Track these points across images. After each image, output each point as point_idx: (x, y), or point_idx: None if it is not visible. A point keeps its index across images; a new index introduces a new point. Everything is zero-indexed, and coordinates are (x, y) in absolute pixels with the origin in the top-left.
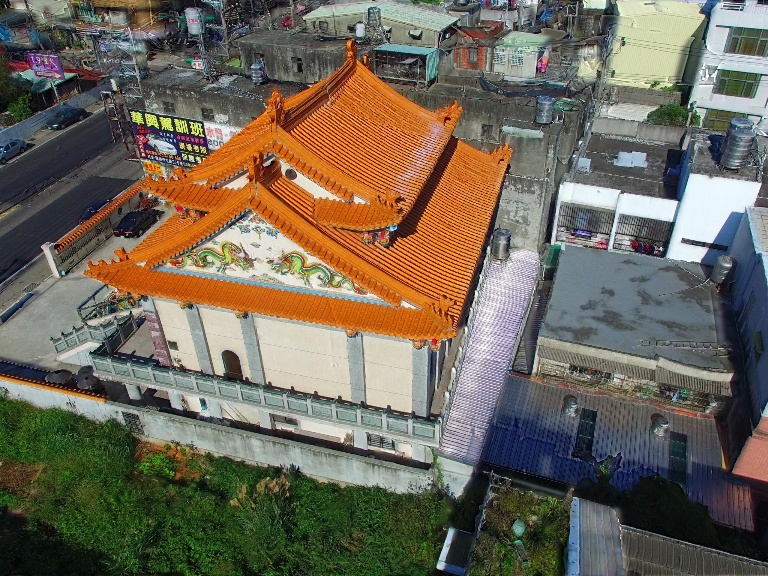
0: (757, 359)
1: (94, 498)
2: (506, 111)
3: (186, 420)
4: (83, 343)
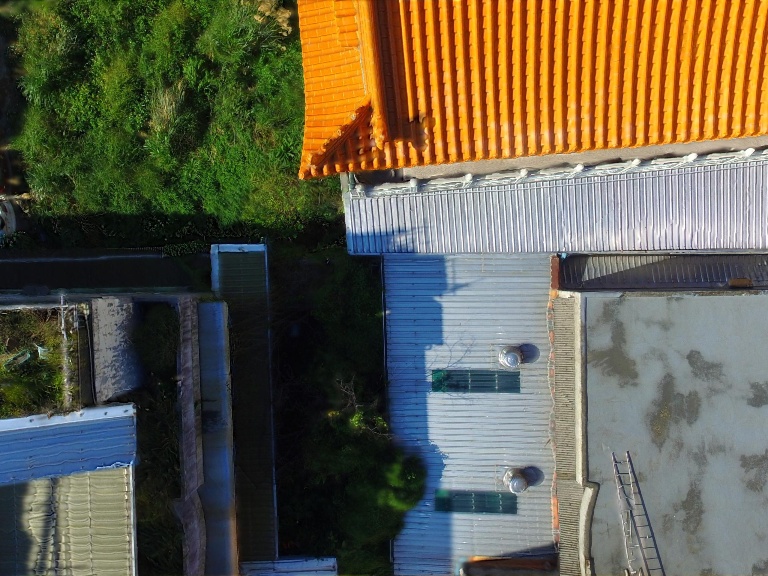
0: None
1: None
2: None
3: None
4: None
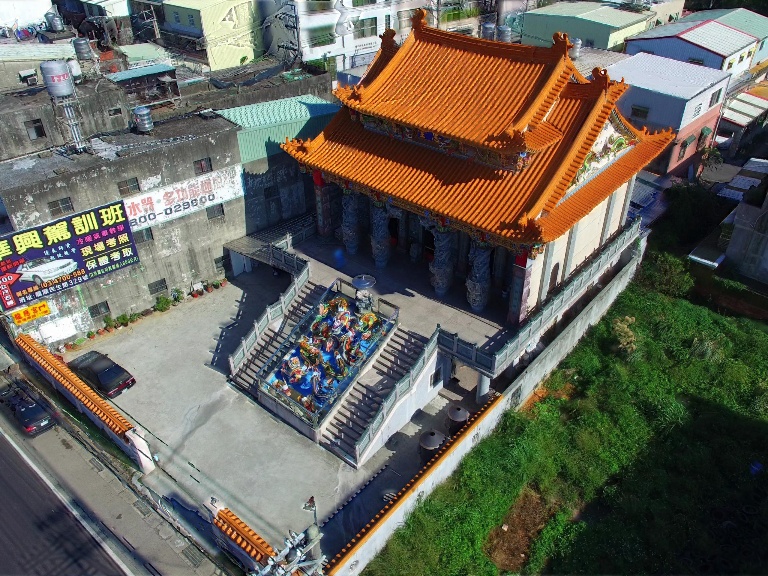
0: (643, 117)
1: (593, 438)
2: (279, 92)
3: (548, 351)
4: (390, 412)
